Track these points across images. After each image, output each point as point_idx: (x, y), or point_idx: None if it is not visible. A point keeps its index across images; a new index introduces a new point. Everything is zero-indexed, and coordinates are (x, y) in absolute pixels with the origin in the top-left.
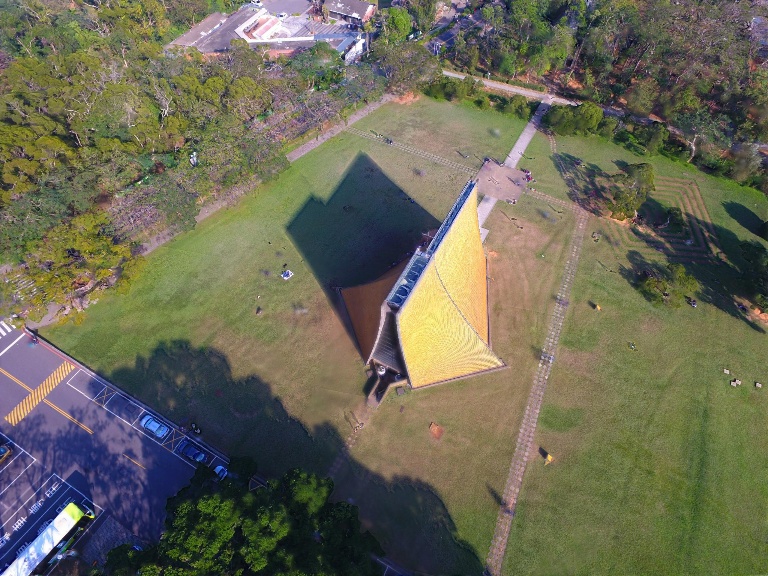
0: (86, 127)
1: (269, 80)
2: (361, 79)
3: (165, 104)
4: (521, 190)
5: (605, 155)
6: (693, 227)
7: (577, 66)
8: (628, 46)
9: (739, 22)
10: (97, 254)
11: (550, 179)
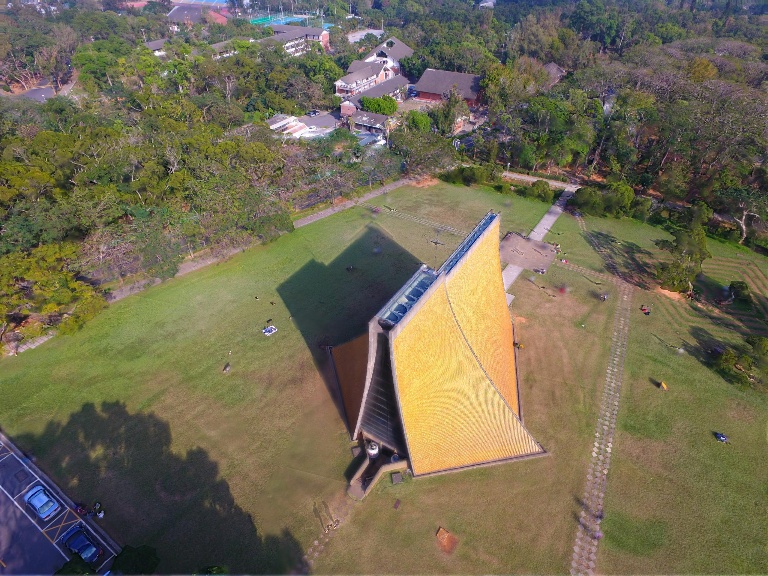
0: (88, 178)
1: (284, 151)
2: (377, 157)
3: (173, 162)
4: (550, 261)
5: (642, 234)
6: (765, 306)
7: (599, 165)
8: (650, 144)
9: (766, 116)
10: (49, 287)
11: (582, 252)
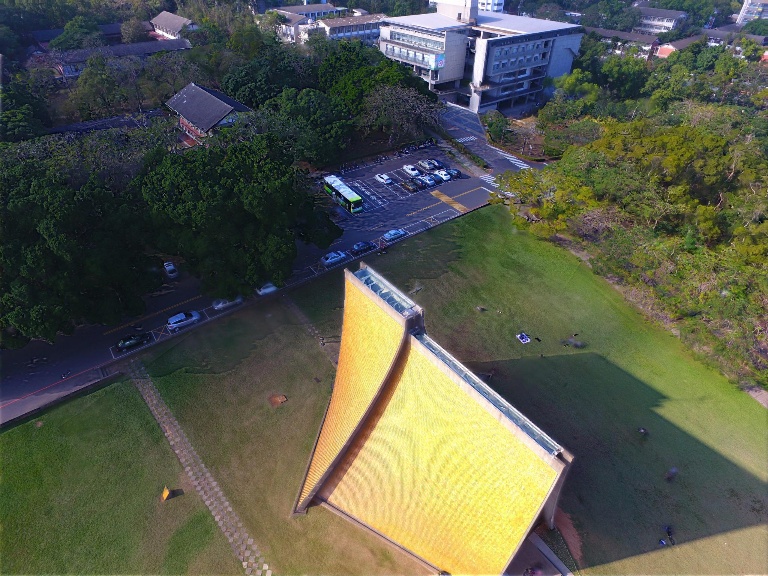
0: None
1: None
2: None
3: None
4: None
5: None
6: None
7: None
8: None
9: None
10: None
11: None
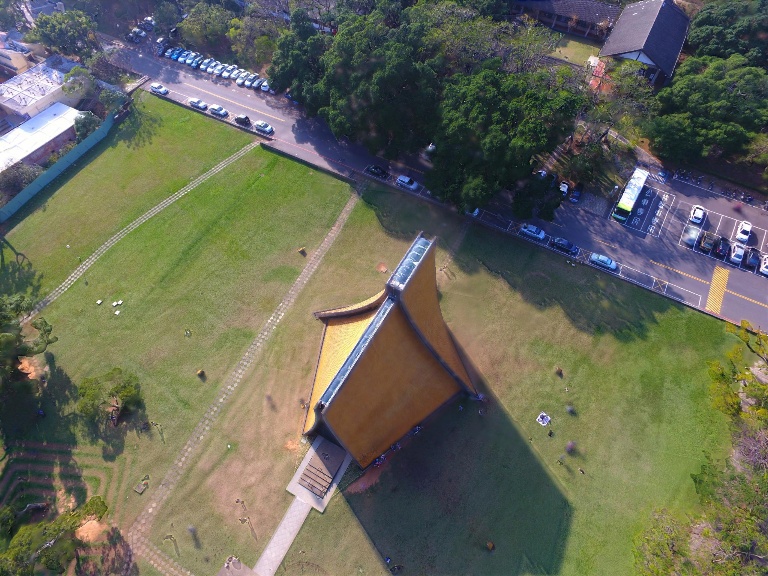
0: None
1: None
2: None
3: None
4: None
5: None
6: None
7: None
8: None
9: None
10: None
11: None
